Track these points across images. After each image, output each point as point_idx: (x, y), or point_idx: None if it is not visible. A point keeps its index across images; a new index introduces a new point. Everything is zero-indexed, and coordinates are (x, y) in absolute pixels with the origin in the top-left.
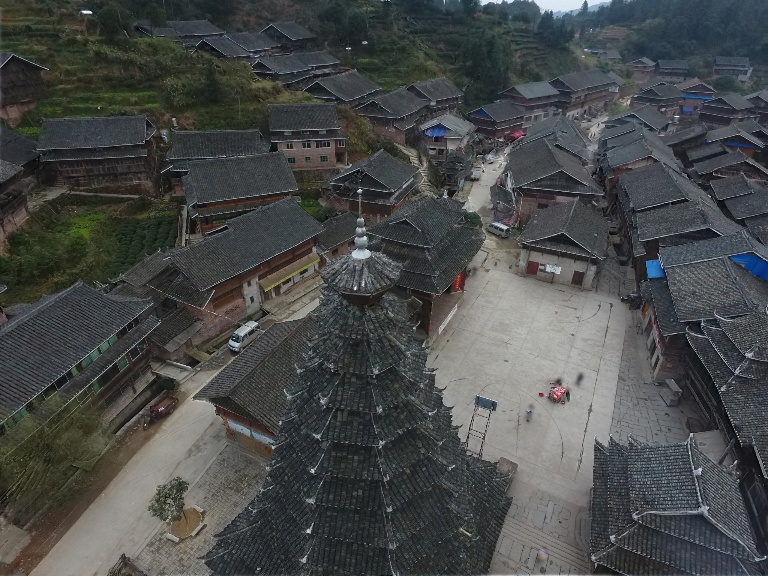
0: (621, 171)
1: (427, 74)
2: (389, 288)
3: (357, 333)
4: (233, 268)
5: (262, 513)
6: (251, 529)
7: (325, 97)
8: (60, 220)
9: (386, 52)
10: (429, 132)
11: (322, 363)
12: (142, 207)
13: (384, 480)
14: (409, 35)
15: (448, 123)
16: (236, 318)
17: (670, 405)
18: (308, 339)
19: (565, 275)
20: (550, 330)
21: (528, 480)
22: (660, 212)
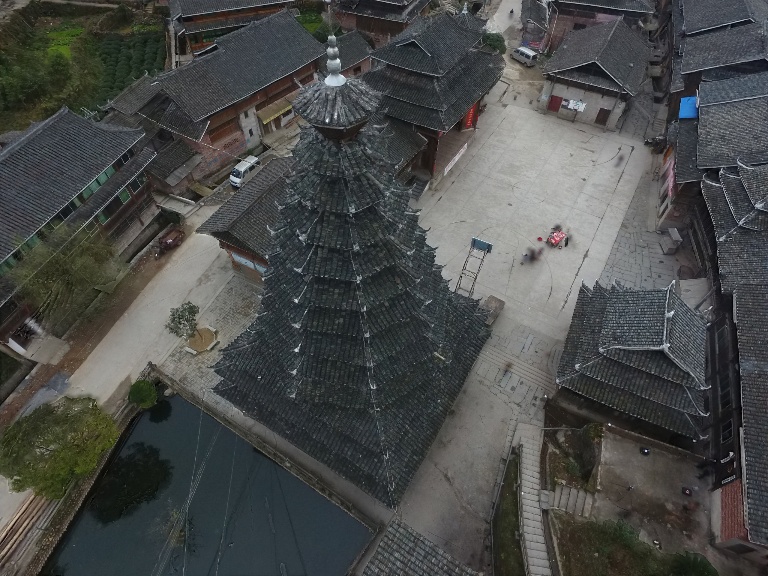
0: None
1: None
2: (365, 121)
3: (332, 170)
4: (227, 96)
5: (259, 334)
6: (251, 346)
7: None
8: (36, 35)
9: None
10: None
11: None
12: (124, 20)
13: (361, 311)
14: None
15: None
16: (236, 152)
17: (667, 253)
18: None
19: (589, 113)
20: (561, 174)
21: (513, 316)
22: (714, 37)
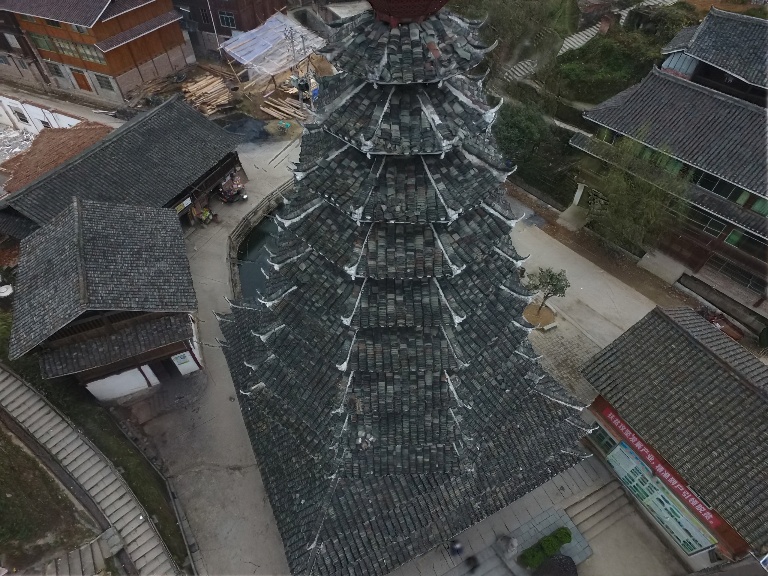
0: None
1: None
2: None
3: None
4: None
5: None
6: None
7: None
8: None
9: None
10: None
11: None
12: None
13: None
14: None
15: None
16: None
17: None
18: None
19: None
20: None
21: None
22: None
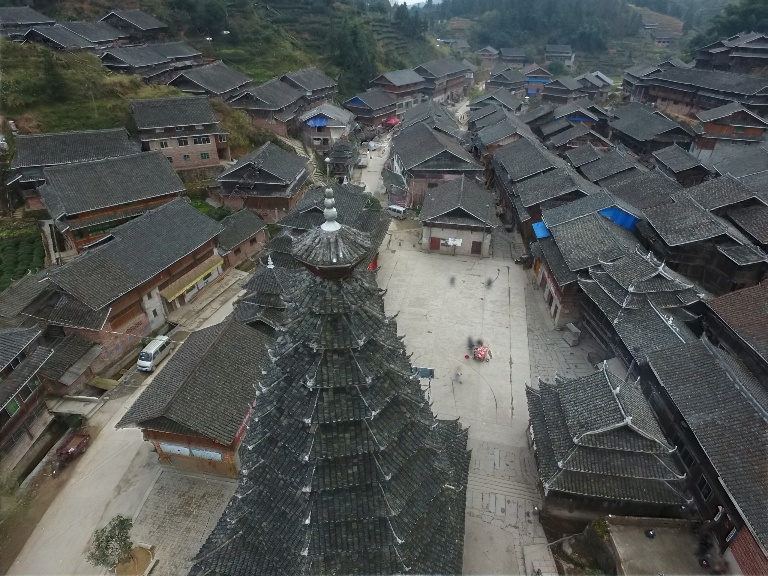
0: (494, 148)
1: (297, 64)
2: (364, 257)
3: (338, 307)
4: (129, 281)
5: (243, 521)
6: (232, 542)
7: (193, 91)
8: None
9: (251, 42)
10: (311, 122)
11: (297, 347)
12: None
13: (381, 449)
14: (272, 24)
15: (329, 112)
16: None
17: (572, 345)
18: (281, 324)
19: (465, 246)
20: (462, 298)
21: (473, 435)
22: (536, 180)
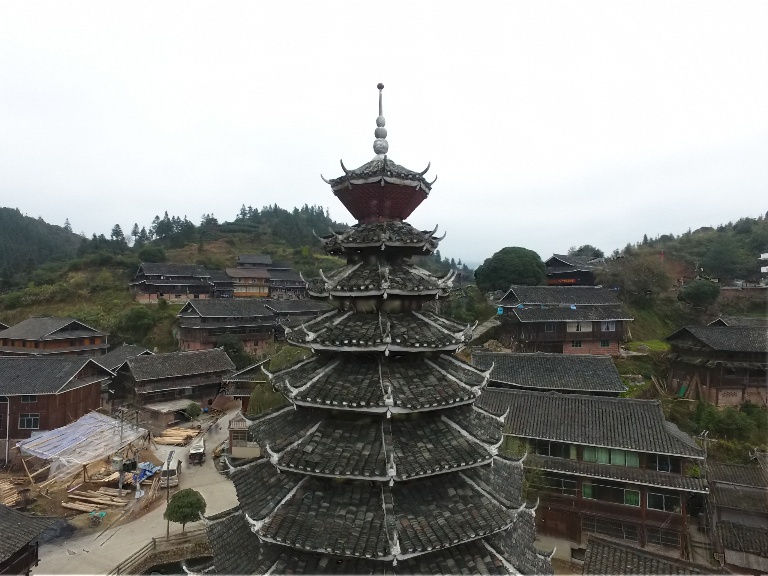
0: None
1: None
2: None
3: None
4: None
5: None
6: None
7: None
8: None
9: None
10: None
11: None
12: None
13: None
14: None
15: None
16: None
17: None
18: None
19: None
20: None
21: None
22: None
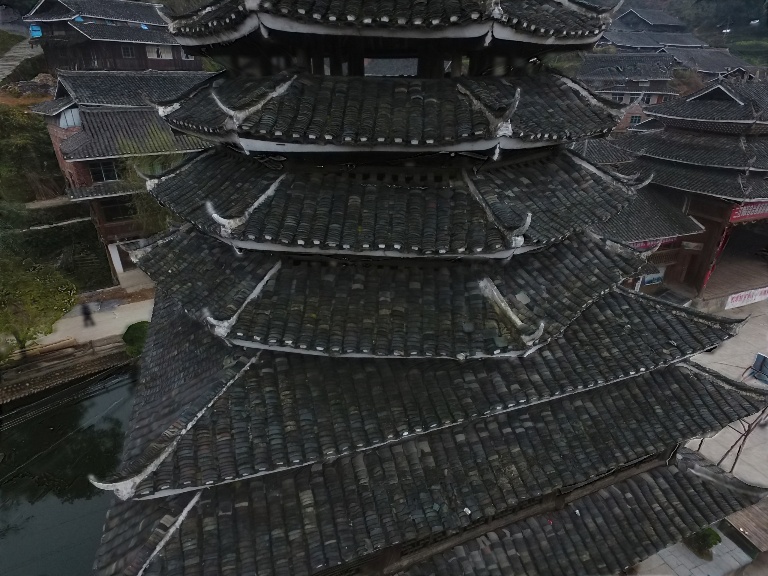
0: None
1: None
2: None
3: None
4: None
5: None
6: None
7: None
8: None
9: None
10: None
11: None
12: None
13: None
14: None
15: None
16: None
17: None
18: None
19: None
20: None
21: None
22: None
